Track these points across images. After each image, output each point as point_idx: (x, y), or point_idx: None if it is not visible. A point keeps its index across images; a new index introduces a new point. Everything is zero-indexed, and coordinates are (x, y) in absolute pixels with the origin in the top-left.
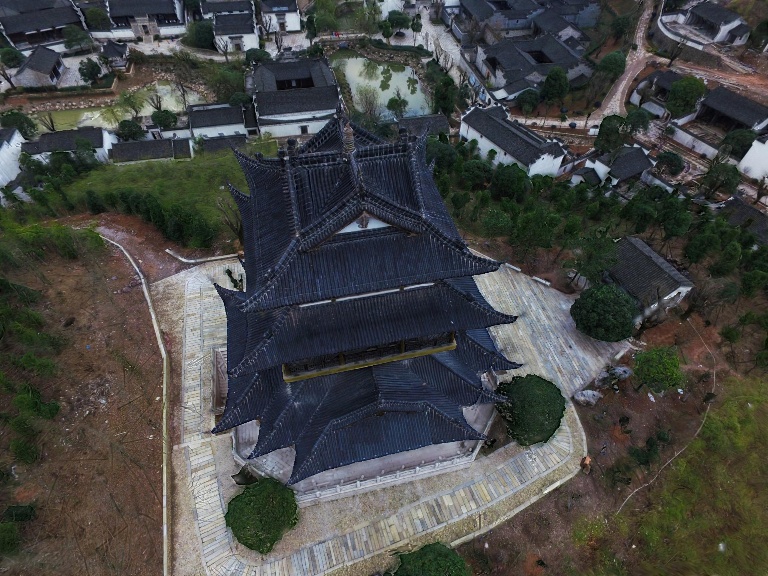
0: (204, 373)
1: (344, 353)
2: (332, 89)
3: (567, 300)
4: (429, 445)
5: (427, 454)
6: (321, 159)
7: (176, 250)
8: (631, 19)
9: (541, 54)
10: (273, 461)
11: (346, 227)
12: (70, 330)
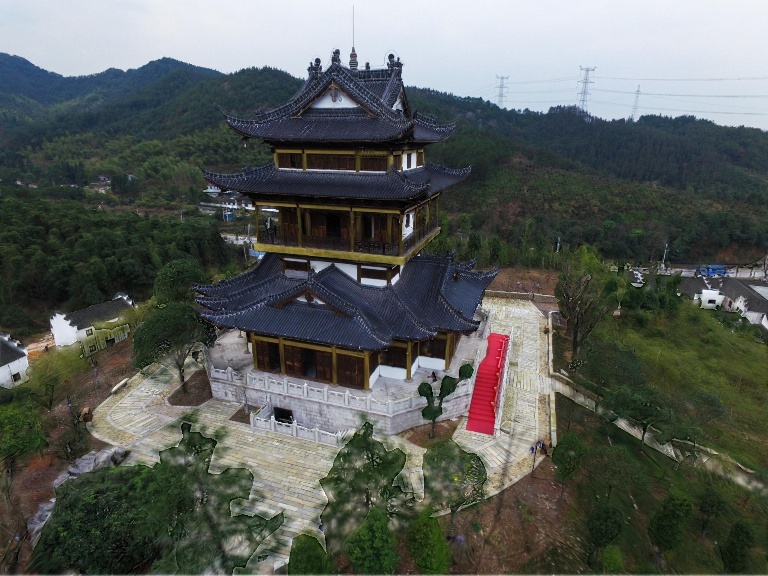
0: None
1: None
2: None
3: None
4: None
5: None
6: None
7: None
8: None
9: None
10: None
11: None
12: None
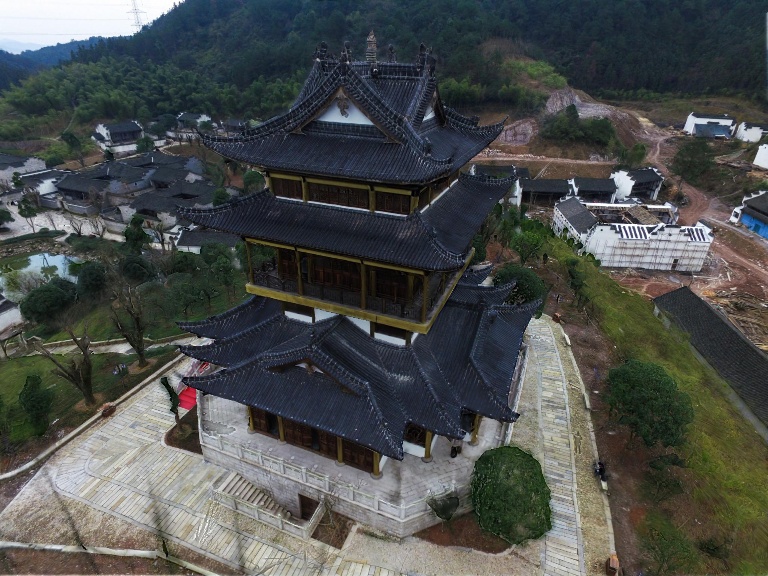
0: (233, 524)
1: (432, 288)
2: None
3: None
4: None
5: None
6: (361, 70)
7: None
8: None
9: (184, 196)
10: (436, 483)
11: None
12: None
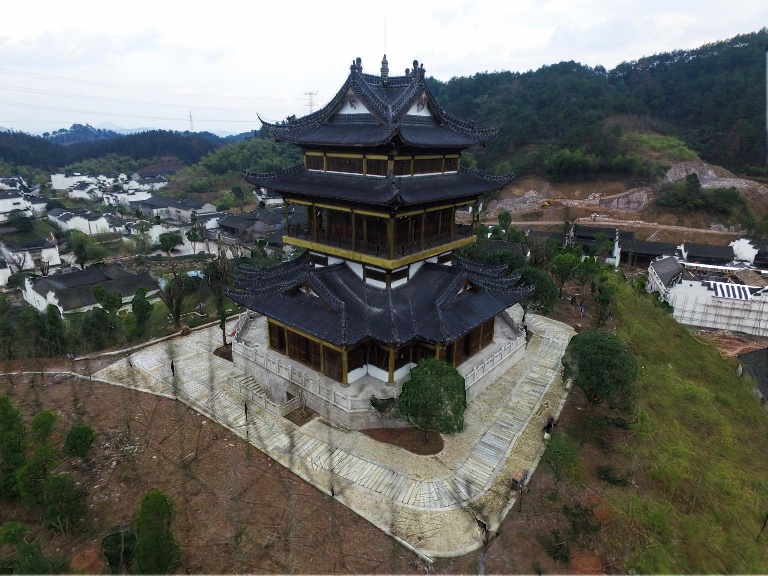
0: (234, 399)
1: None
2: (144, 275)
3: None
4: (491, 346)
5: (495, 349)
6: (372, 80)
7: (91, 354)
8: None
9: None
10: None
11: (412, 109)
12: None
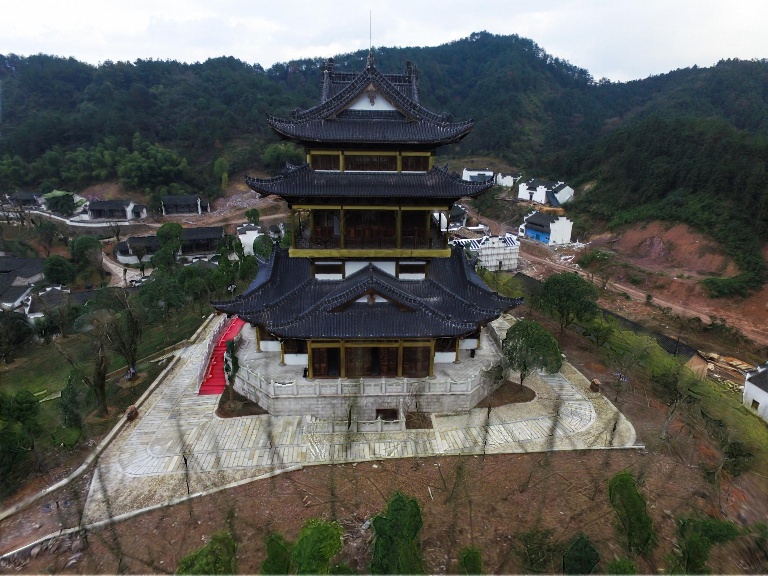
0: (339, 441)
1: None
2: None
3: None
4: None
5: None
6: None
7: (5, 508)
8: None
9: None
10: (474, 371)
11: None
12: None
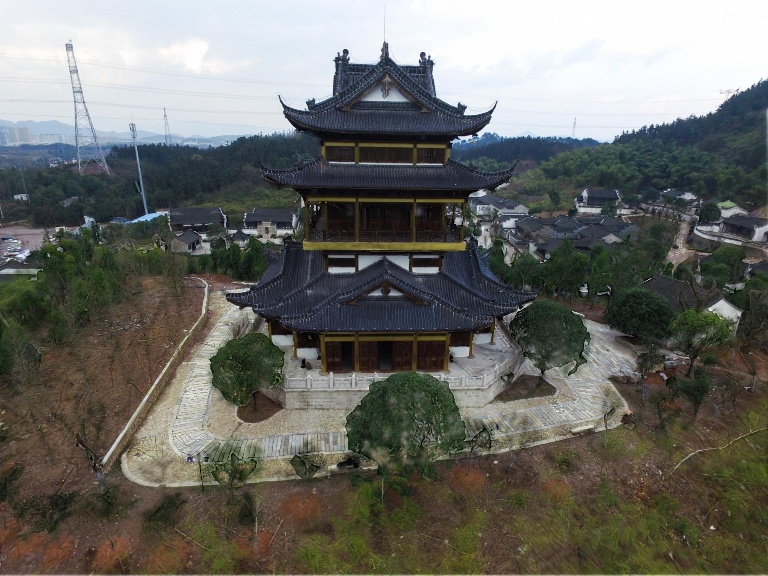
0: None
1: None
2: None
3: (604, 327)
4: (438, 373)
5: None
6: (364, 69)
7: None
8: (667, 227)
9: (587, 249)
10: None
11: (373, 95)
12: (136, 296)
